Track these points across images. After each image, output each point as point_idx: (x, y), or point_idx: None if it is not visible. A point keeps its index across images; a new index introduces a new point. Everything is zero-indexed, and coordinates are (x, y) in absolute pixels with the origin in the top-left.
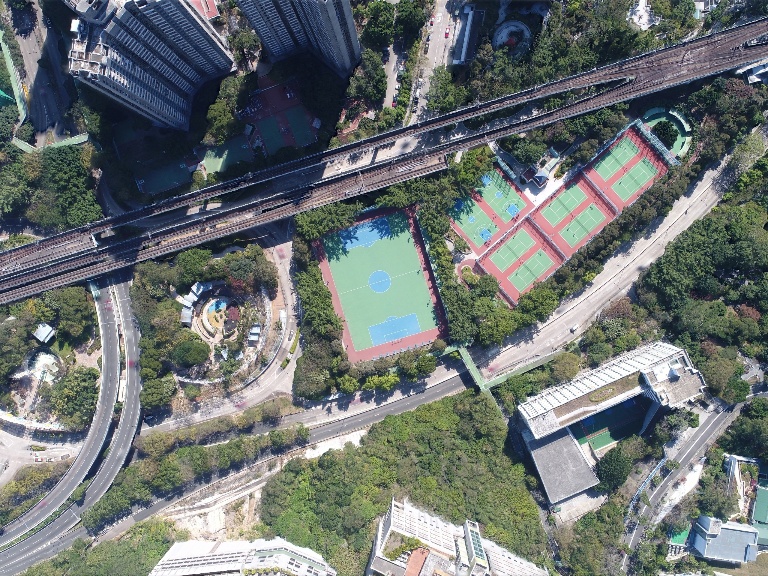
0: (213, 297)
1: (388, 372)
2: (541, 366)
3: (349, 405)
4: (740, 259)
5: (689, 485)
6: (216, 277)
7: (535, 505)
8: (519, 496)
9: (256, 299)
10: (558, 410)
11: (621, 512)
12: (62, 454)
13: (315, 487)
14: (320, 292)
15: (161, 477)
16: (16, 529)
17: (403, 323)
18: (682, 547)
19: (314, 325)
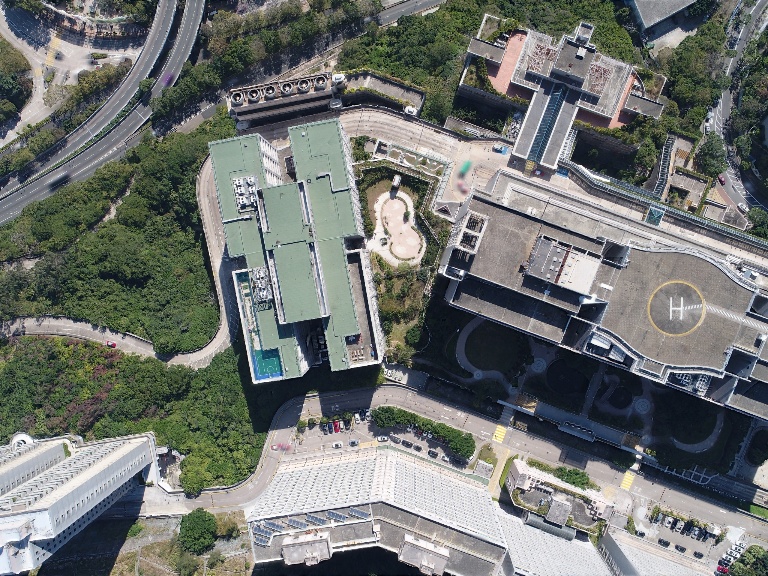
0: None
1: None
2: None
3: None
4: None
5: None
6: None
7: (628, 36)
8: (611, 28)
9: None
10: None
11: (721, 28)
12: (124, 60)
13: (394, 46)
14: None
15: (231, 55)
16: (80, 138)
17: None
18: None
19: None
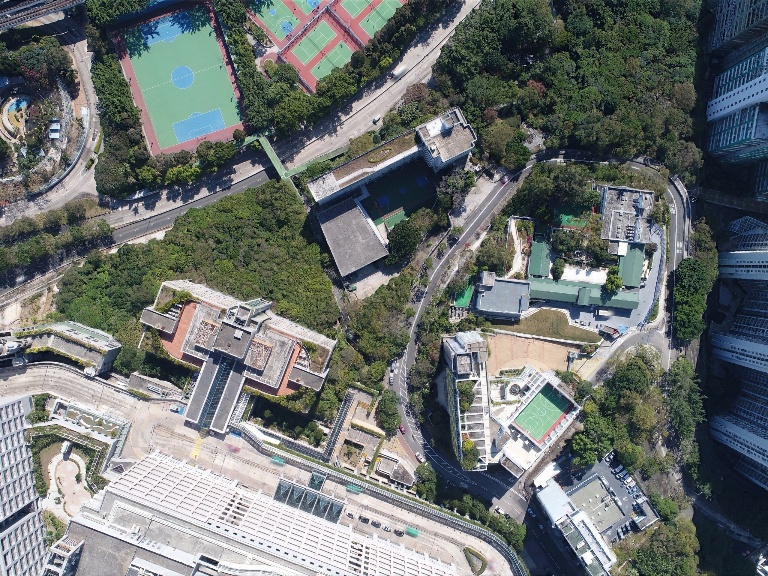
0: (13, 96)
1: (191, 166)
2: (342, 155)
3: (156, 204)
4: (521, 29)
5: (472, 249)
6: (9, 68)
7: (328, 281)
8: (312, 273)
9: (54, 93)
10: (337, 172)
11: (409, 281)
12: None
13: None
14: (114, 79)
15: None
16: None
17: (207, 119)
18: (465, 308)
19: (108, 113)
